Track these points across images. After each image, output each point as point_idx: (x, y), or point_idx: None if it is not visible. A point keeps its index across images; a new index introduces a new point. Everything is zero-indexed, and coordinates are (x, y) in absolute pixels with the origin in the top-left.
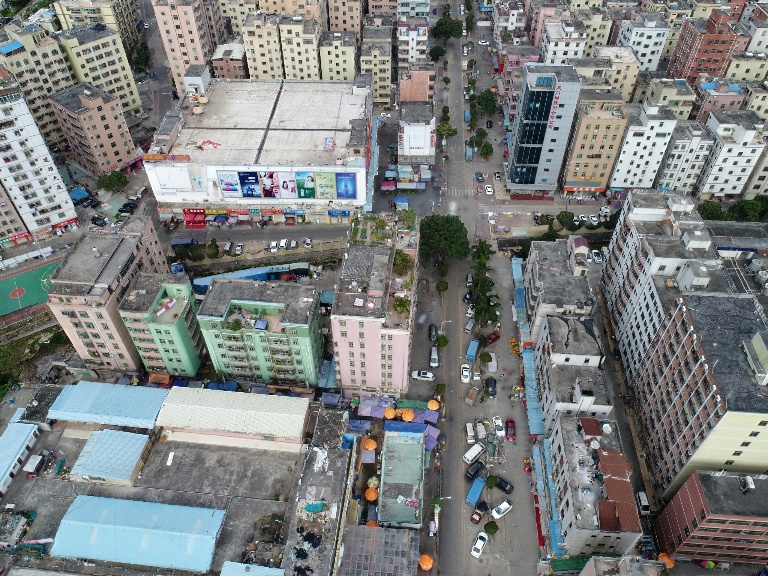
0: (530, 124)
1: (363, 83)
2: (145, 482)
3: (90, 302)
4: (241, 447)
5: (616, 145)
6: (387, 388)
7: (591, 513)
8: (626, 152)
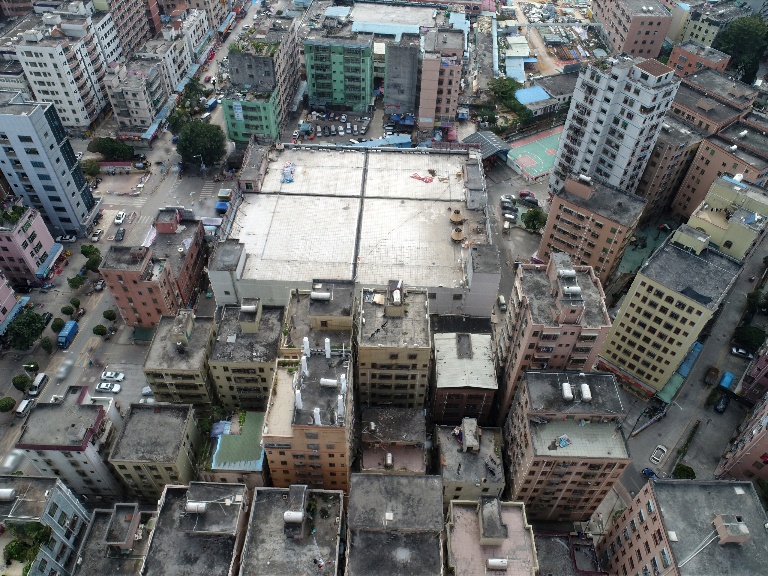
0: None
1: (228, 249)
2: None
3: None
4: None
5: None
6: None
7: None
8: None
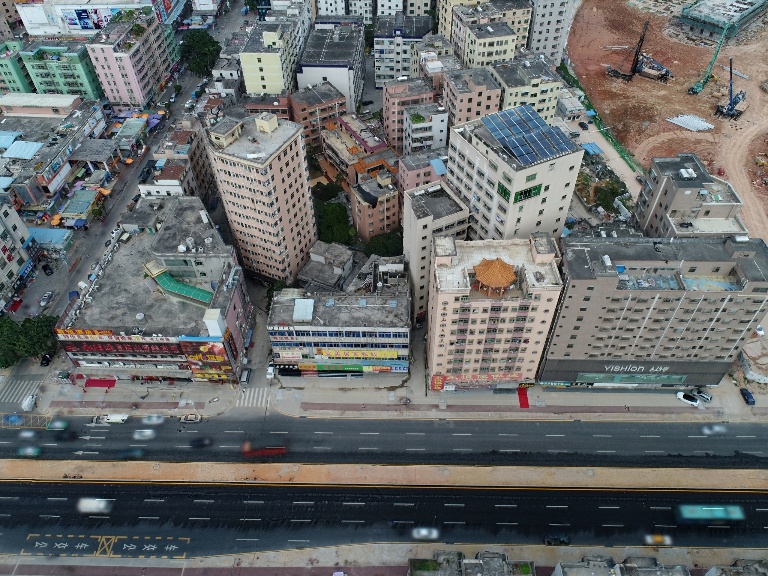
0: None
1: None
2: None
3: None
4: (42, 117)
5: None
6: (134, 102)
7: None
8: None
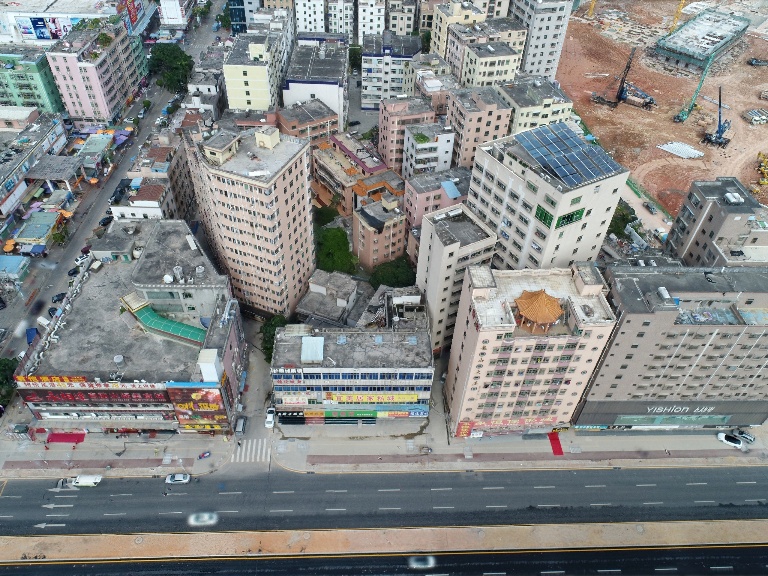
0: None
1: None
2: None
3: None
4: None
5: (290, 6)
6: (98, 117)
7: None
8: (299, 12)
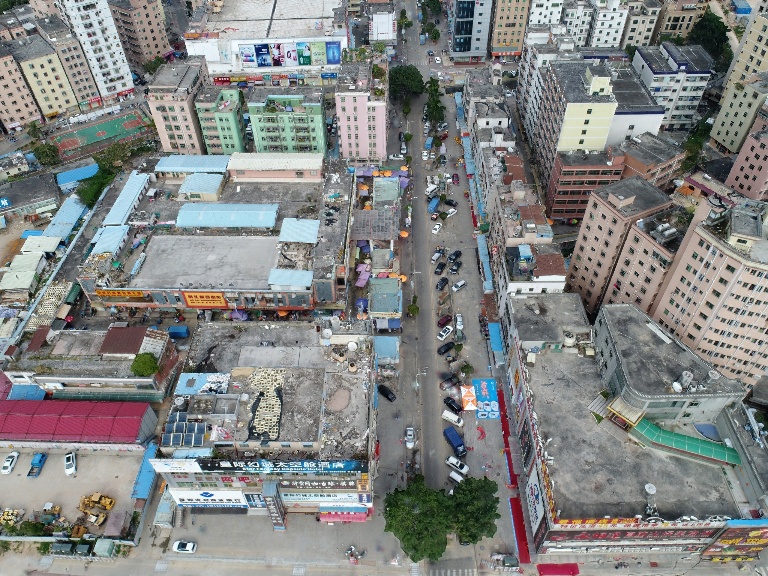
0: (463, 2)
1: None
2: (225, 199)
3: (176, 99)
4: (283, 182)
5: (525, 15)
6: (373, 157)
7: (499, 184)
8: (533, 21)
